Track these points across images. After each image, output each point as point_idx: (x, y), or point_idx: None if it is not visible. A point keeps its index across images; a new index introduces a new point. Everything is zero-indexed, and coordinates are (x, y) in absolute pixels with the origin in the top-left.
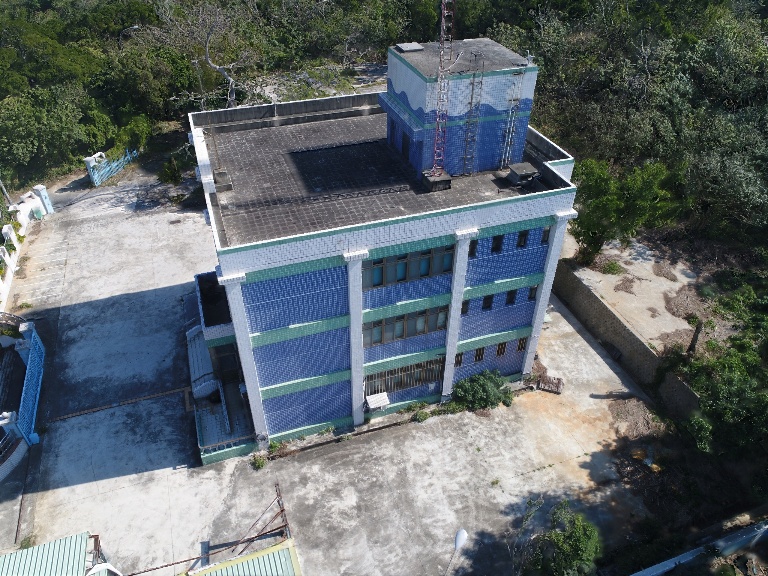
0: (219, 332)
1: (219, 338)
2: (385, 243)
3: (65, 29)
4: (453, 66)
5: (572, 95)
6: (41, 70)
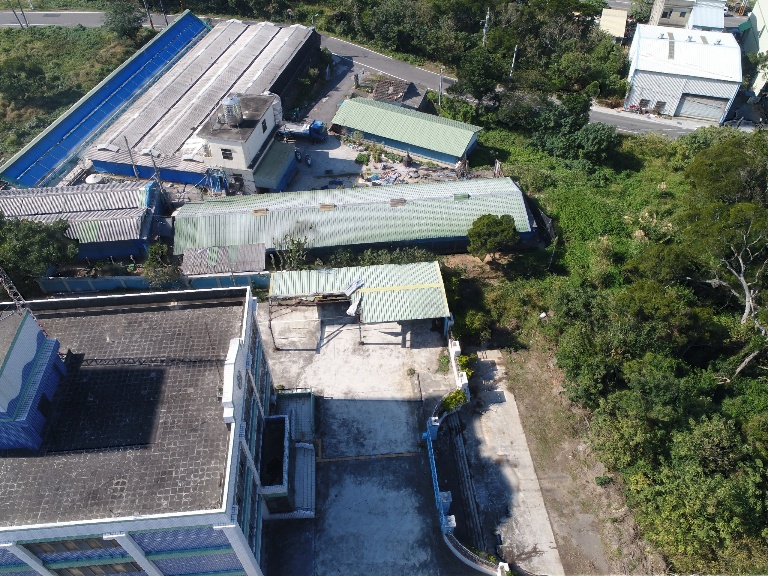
0: None
1: None
2: None
3: None
4: None
5: None
6: None
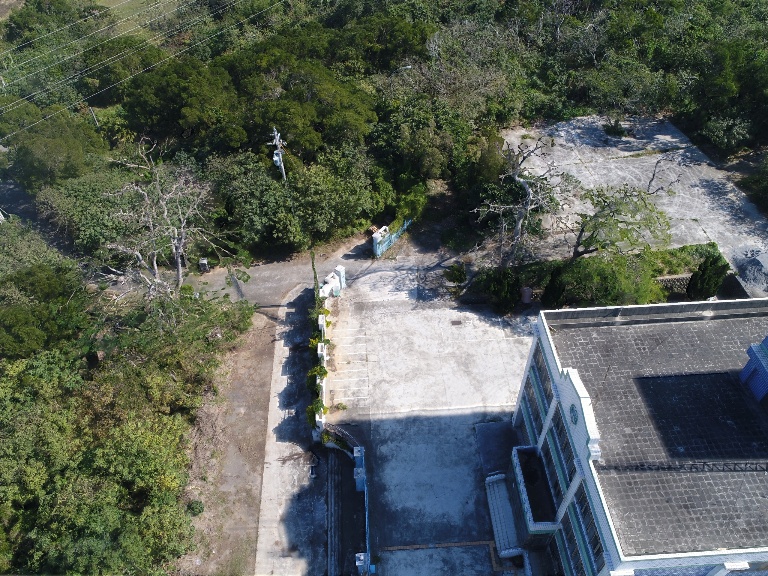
0: (544, 527)
1: (542, 530)
2: (766, 559)
3: (330, 42)
4: None
5: None
6: (326, 116)
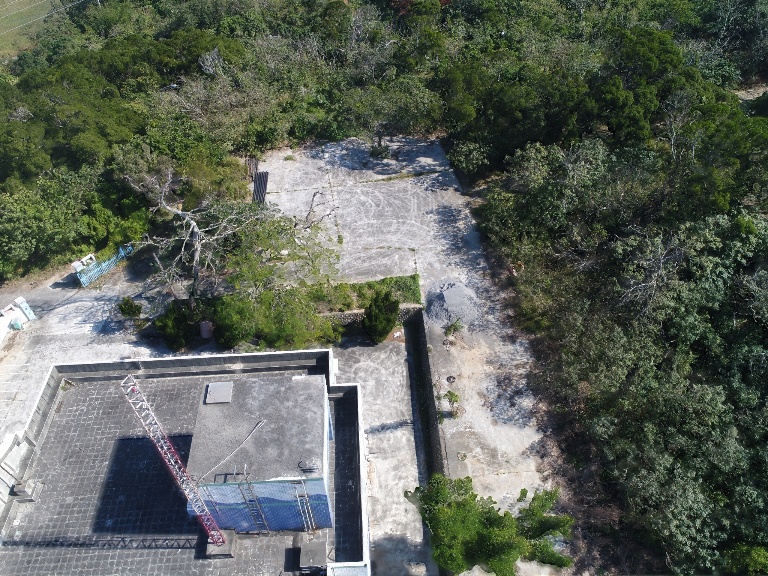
0: None
1: None
2: None
3: None
4: (231, 457)
5: (592, 253)
6: None
